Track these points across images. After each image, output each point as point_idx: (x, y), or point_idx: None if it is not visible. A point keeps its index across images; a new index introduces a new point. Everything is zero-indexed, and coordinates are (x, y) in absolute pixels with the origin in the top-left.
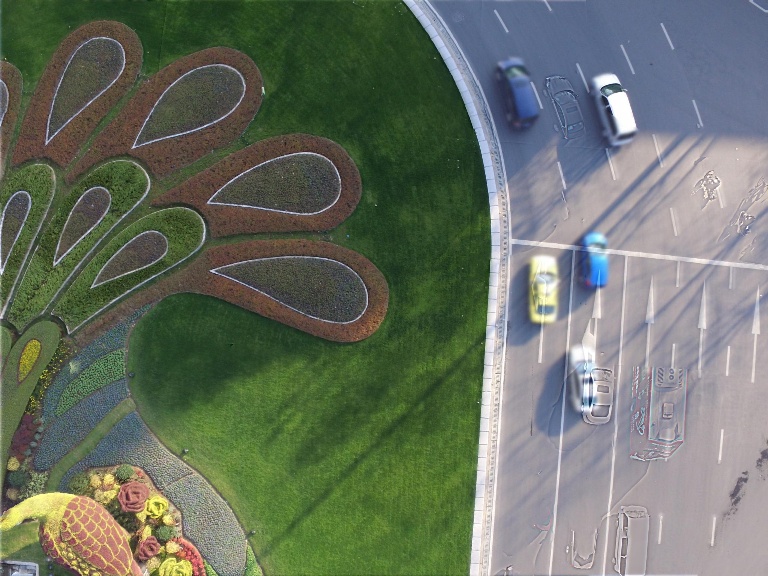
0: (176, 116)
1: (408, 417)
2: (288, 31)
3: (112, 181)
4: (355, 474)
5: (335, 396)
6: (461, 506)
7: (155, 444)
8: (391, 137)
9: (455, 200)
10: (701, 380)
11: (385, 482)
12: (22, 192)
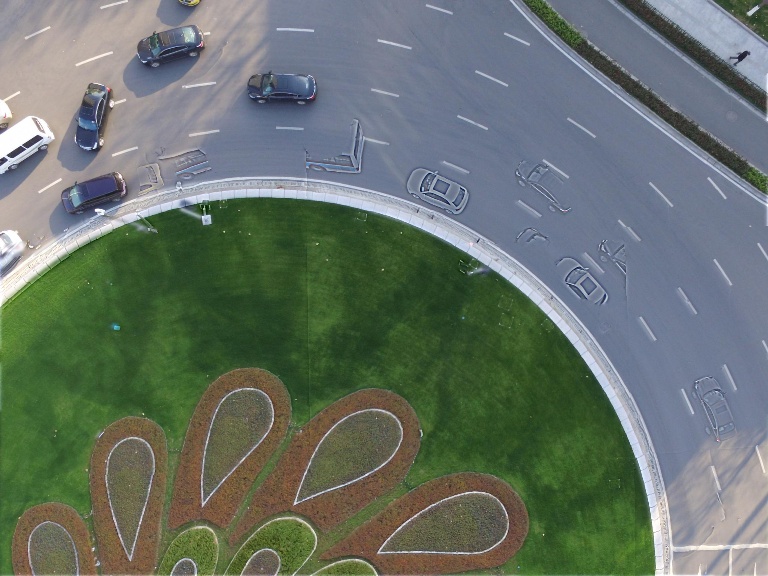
0: (336, 470)
1: None
2: (438, 364)
3: (279, 543)
4: None
5: None
6: None
7: None
8: (552, 465)
9: (619, 520)
10: None
11: None
12: (186, 560)
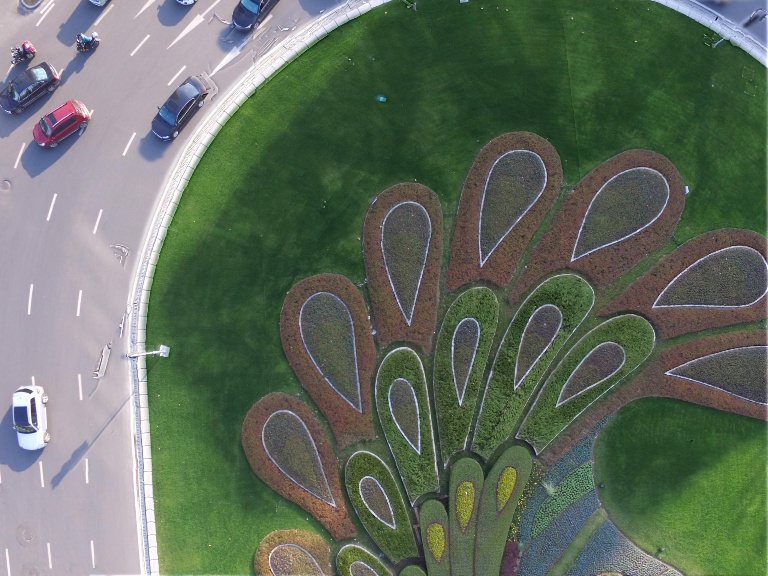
0: (612, 224)
1: None
2: (694, 127)
3: (561, 297)
4: None
5: None
6: None
7: (631, 548)
8: None
9: None
10: None
11: None
12: (468, 319)
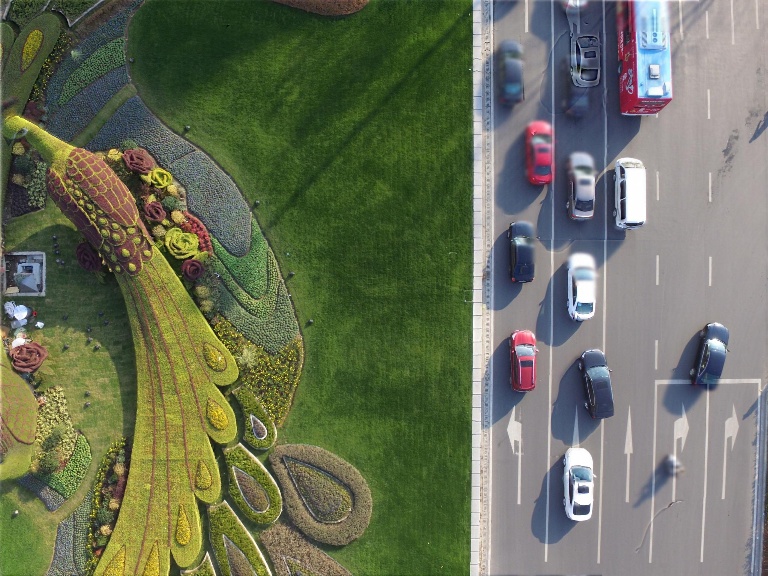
0: None
1: (403, 84)
2: None
3: None
4: (354, 141)
5: (330, 67)
6: (460, 169)
7: (157, 124)
8: None
9: None
10: (684, 42)
11: (384, 147)
12: None
